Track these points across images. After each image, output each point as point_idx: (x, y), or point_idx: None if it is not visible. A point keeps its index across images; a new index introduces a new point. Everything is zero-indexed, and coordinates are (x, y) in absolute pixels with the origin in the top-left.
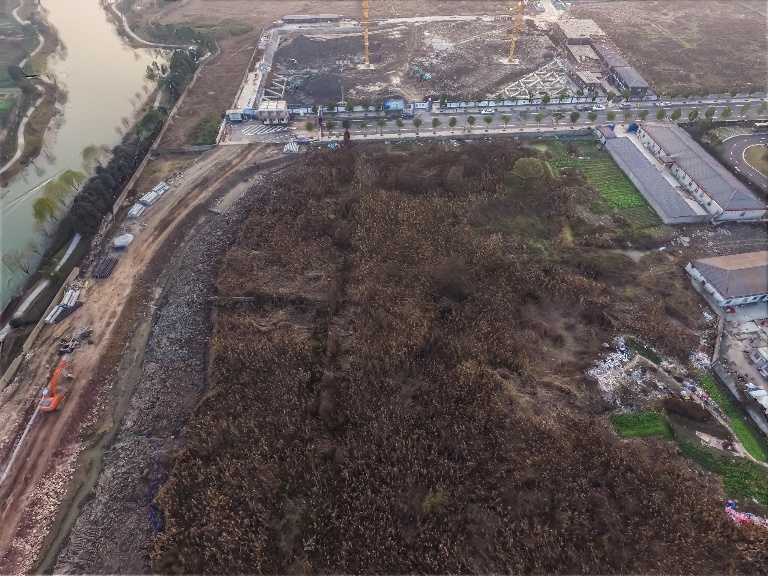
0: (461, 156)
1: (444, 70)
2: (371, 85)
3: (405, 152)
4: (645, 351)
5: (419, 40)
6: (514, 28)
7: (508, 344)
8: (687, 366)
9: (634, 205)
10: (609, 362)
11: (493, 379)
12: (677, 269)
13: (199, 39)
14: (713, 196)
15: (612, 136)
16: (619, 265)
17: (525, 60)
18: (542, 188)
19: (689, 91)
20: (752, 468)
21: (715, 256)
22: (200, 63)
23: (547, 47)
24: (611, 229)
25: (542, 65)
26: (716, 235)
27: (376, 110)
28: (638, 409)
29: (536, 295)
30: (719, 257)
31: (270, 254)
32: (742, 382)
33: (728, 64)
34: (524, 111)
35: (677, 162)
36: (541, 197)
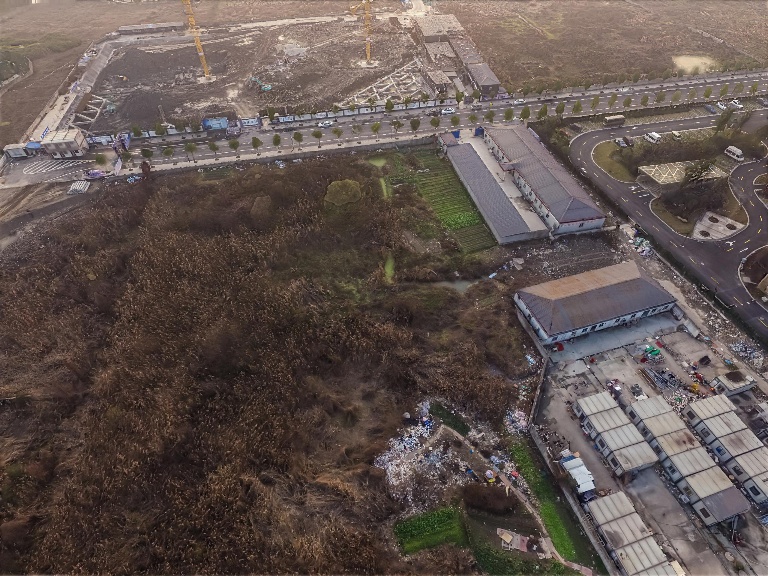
0: (274, 182)
1: (286, 79)
2: (202, 101)
3: (219, 180)
4: (451, 418)
5: (270, 46)
6: (377, 27)
7: (273, 437)
8: (499, 432)
9: (468, 224)
10: (406, 441)
11: (250, 490)
12: (504, 301)
13: (8, 59)
14: (549, 207)
15: (453, 143)
16: (438, 303)
17: (385, 61)
18: (367, 213)
19: (540, 86)
20: (558, 575)
21: (549, 279)
22: (2, 87)
23: (407, 46)
24: (437, 257)
25: (400, 66)
26: (552, 252)
27: (196, 131)
28: (430, 506)
29: (329, 358)
30: (548, 282)
31: (3, 337)
32: (559, 447)
33: (588, 54)
34: (367, 120)
35: (517, 169)
36: (363, 224)
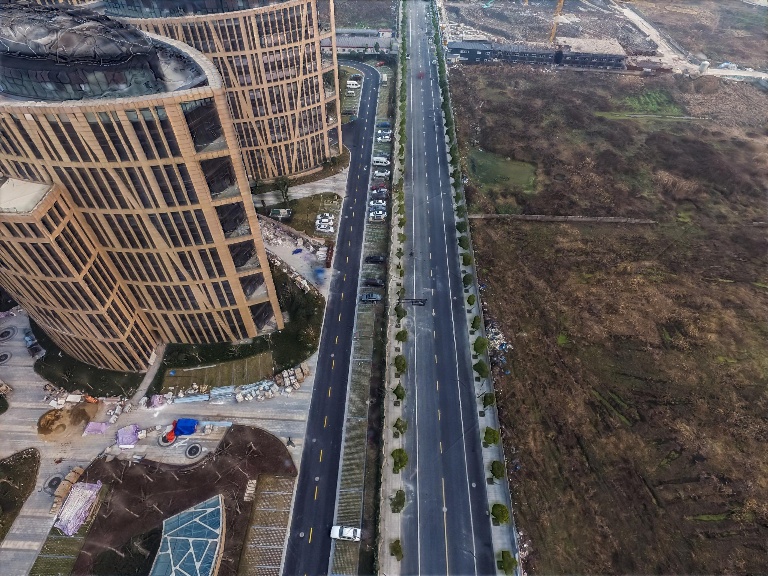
0: None
1: (495, 9)
2: None
3: None
4: None
5: None
6: None
7: None
8: None
9: None
10: None
11: None
12: None
13: None
14: None
15: None
16: None
17: None
18: None
19: None
20: None
21: None
22: None
23: None
24: None
25: None
26: None
27: None
28: None
29: None
30: None
31: None
32: None
33: None
34: (430, 24)
35: None
36: None
